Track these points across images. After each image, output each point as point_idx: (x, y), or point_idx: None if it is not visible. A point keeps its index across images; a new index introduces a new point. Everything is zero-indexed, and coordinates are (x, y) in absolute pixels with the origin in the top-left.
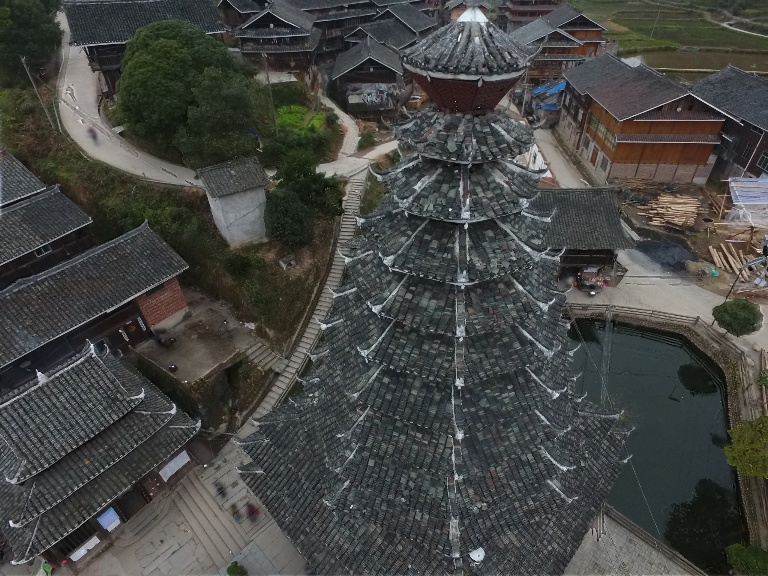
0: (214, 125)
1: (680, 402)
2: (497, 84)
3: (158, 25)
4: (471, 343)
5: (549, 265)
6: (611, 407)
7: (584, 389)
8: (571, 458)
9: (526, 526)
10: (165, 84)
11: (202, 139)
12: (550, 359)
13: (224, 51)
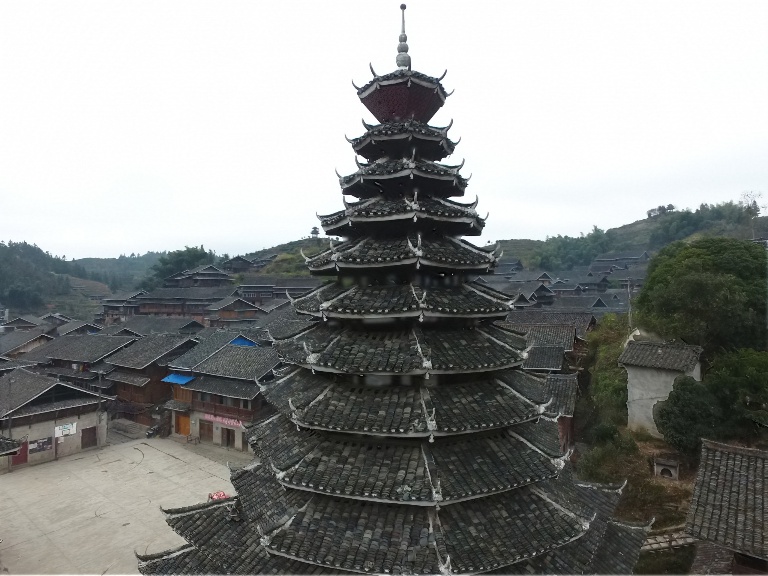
0: (661, 304)
1: None
2: (371, 99)
3: (702, 240)
4: (324, 290)
5: (403, 252)
6: None
7: None
8: (331, 557)
9: (262, 560)
10: (669, 280)
11: (648, 316)
12: (359, 355)
13: (765, 261)
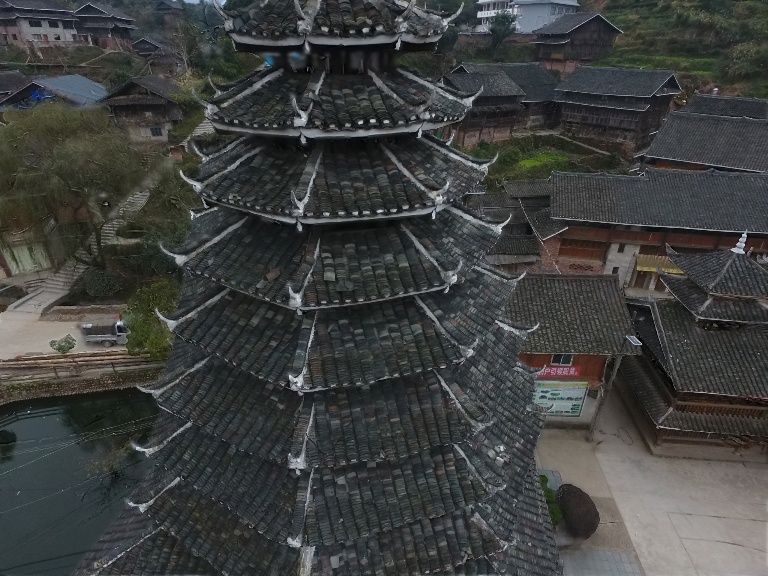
0: None
1: (1, 489)
2: None
3: None
4: None
5: None
6: (151, 417)
7: (4, 568)
8: None
9: None
10: None
11: None
12: None
13: None
